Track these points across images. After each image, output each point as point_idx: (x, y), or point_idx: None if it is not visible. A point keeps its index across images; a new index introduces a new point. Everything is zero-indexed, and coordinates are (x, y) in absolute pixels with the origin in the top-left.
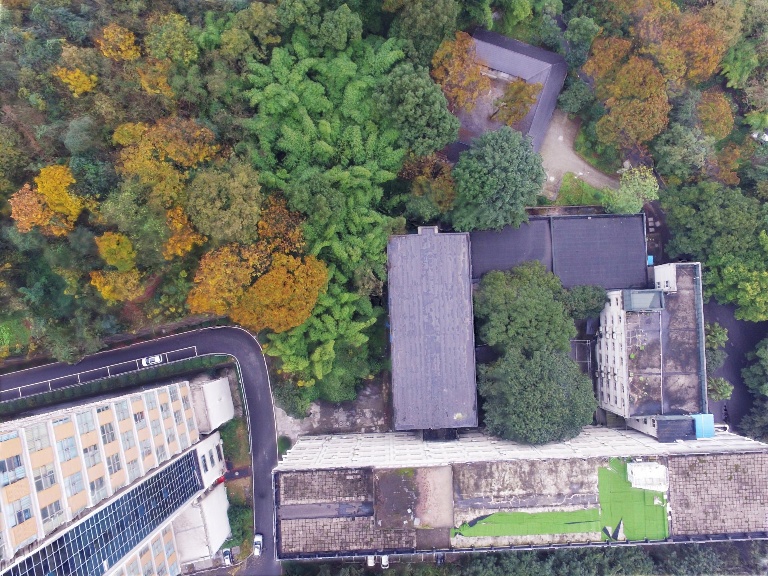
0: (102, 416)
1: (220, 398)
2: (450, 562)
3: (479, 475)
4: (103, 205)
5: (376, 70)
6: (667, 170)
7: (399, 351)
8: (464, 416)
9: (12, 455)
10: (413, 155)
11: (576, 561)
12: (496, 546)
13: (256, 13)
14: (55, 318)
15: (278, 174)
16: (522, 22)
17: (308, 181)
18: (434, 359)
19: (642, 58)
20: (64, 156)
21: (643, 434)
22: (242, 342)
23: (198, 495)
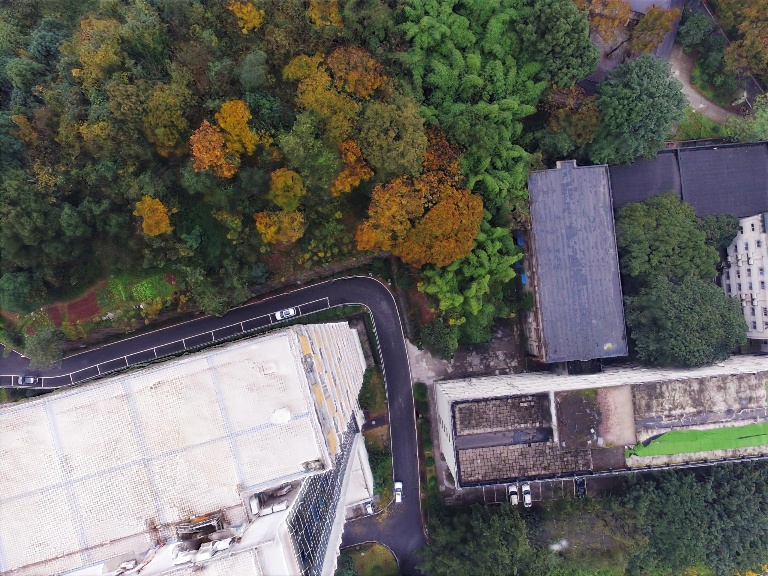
0: None
1: (359, 346)
2: (591, 497)
3: (650, 396)
4: (283, 139)
5: (518, 2)
6: None
7: (546, 285)
8: (614, 346)
9: None
10: (556, 87)
11: (736, 480)
12: (671, 464)
13: None
14: None
15: (429, 110)
16: None
17: (461, 115)
18: (581, 291)
19: None
20: (230, 96)
21: None
22: (373, 291)
23: None
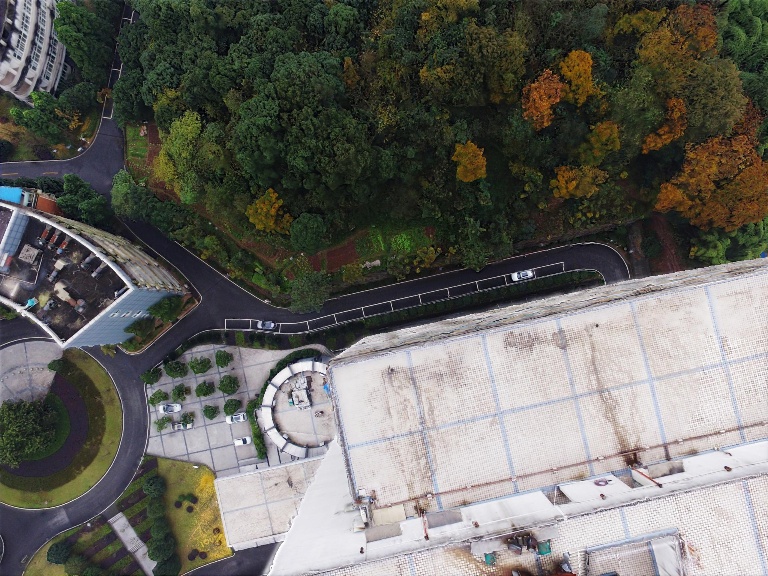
0: None
1: None
2: None
3: None
4: (621, 91)
5: None
6: None
7: None
8: None
9: None
10: None
11: None
12: None
13: None
14: None
15: None
16: None
17: None
18: None
19: None
20: None
21: None
22: (607, 259)
23: None
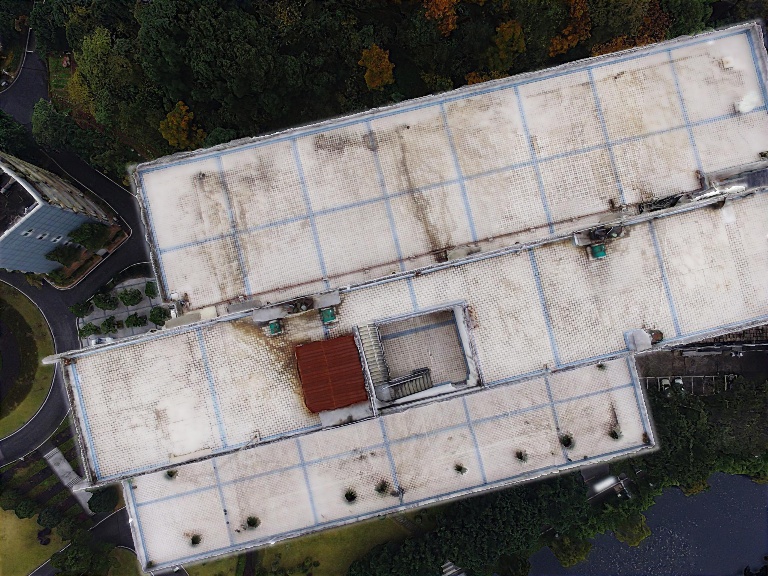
0: None
1: None
2: None
3: None
4: None
5: None
6: None
7: None
8: None
9: None
10: None
11: None
12: None
13: None
14: None
15: None
16: None
17: None
18: (761, 178)
19: None
20: None
21: None
22: None
23: None
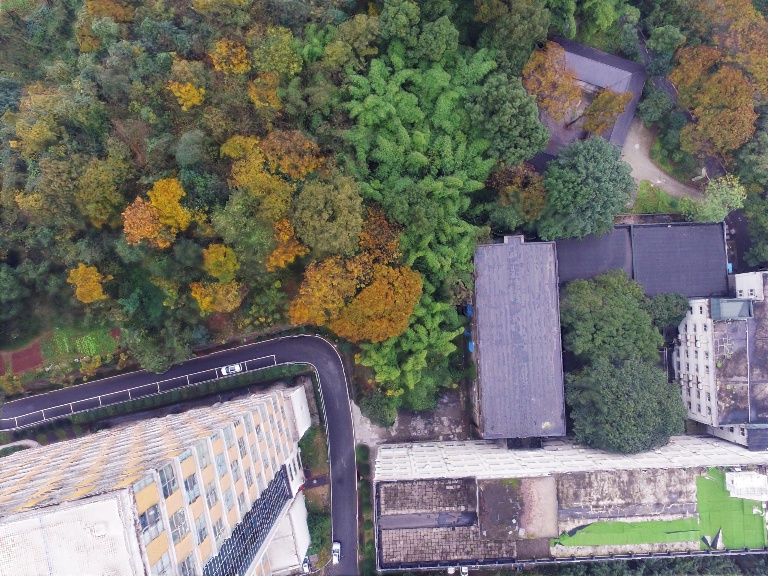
0: (237, 430)
1: (301, 407)
2: (529, 569)
3: (578, 485)
4: (214, 218)
5: (468, 81)
6: (750, 178)
7: (487, 360)
8: (552, 425)
9: (190, 474)
10: (503, 165)
11: (668, 570)
12: (596, 556)
13: (359, 25)
14: (144, 328)
15: (372, 185)
16: (600, 31)
17: (404, 192)
18: (522, 368)
19: (729, 67)
20: (169, 168)
21: (729, 442)
22: (320, 350)
23: (289, 504)
